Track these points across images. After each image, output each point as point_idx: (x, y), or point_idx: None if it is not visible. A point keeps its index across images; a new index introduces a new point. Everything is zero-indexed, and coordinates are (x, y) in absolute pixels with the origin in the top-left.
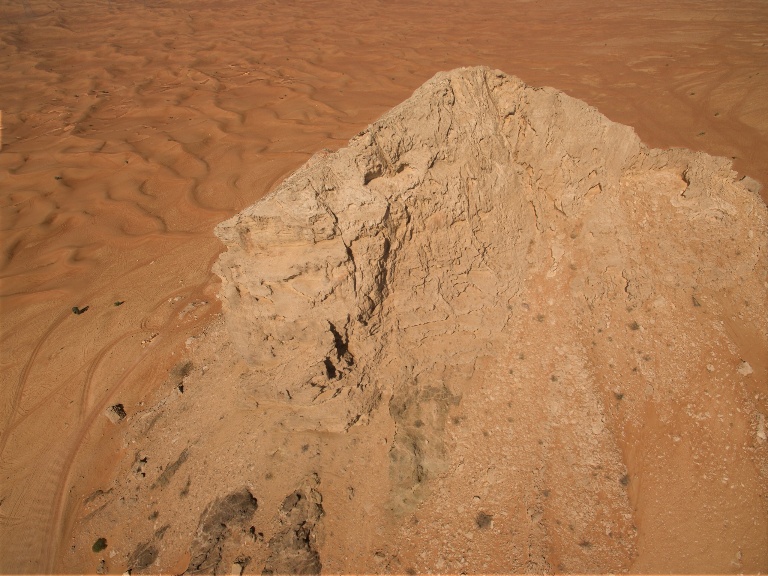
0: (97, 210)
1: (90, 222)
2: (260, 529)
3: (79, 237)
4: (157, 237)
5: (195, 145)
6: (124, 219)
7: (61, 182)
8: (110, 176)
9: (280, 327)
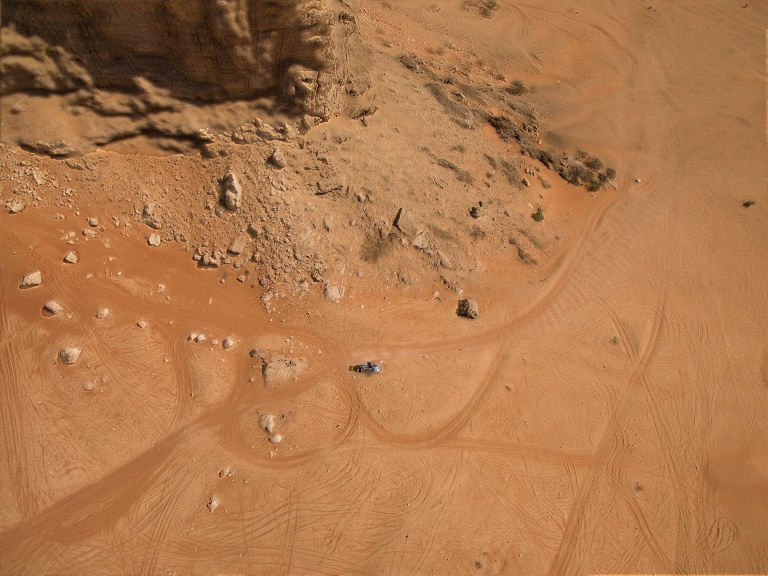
0: None
1: None
2: None
3: None
4: None
5: None
6: None
7: None
8: None
9: None
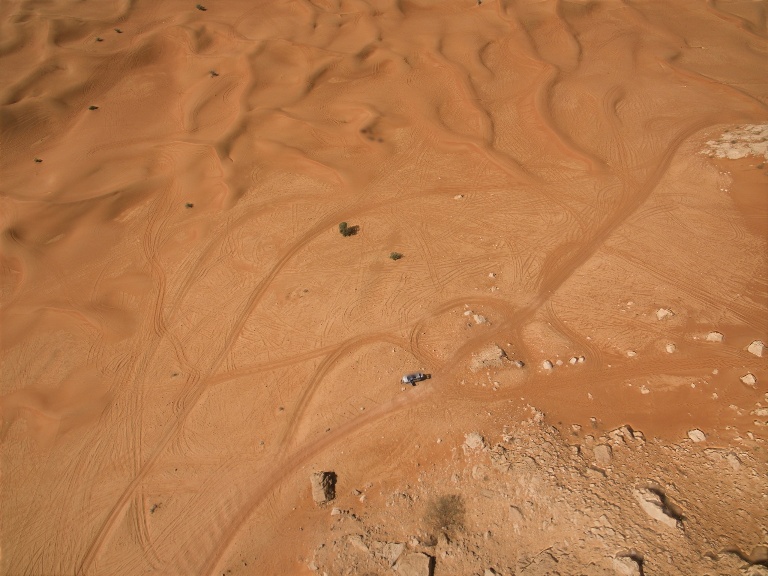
0: (419, 62)
1: (405, 77)
2: None
3: (386, 96)
4: (477, 150)
5: (574, 8)
6: (445, 93)
7: (397, 2)
8: (452, 15)
9: None
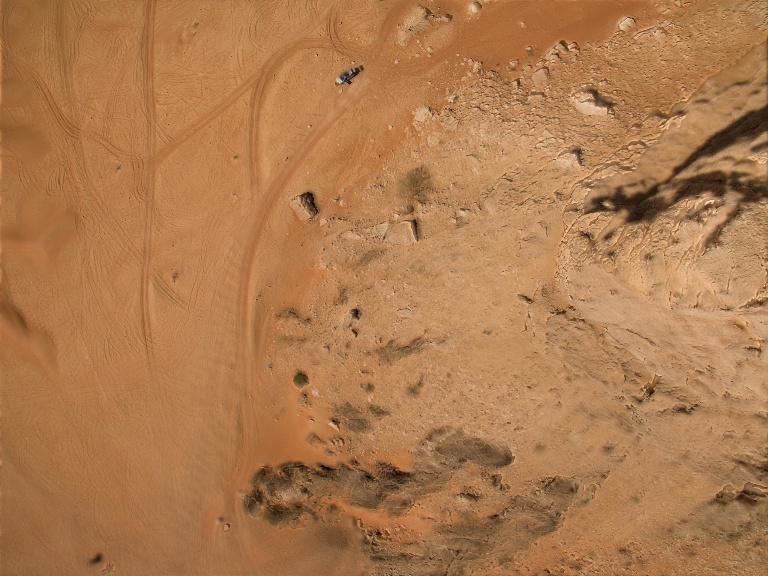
0: None
1: None
2: (508, 482)
3: None
4: None
5: None
6: None
7: None
8: None
9: (755, 407)
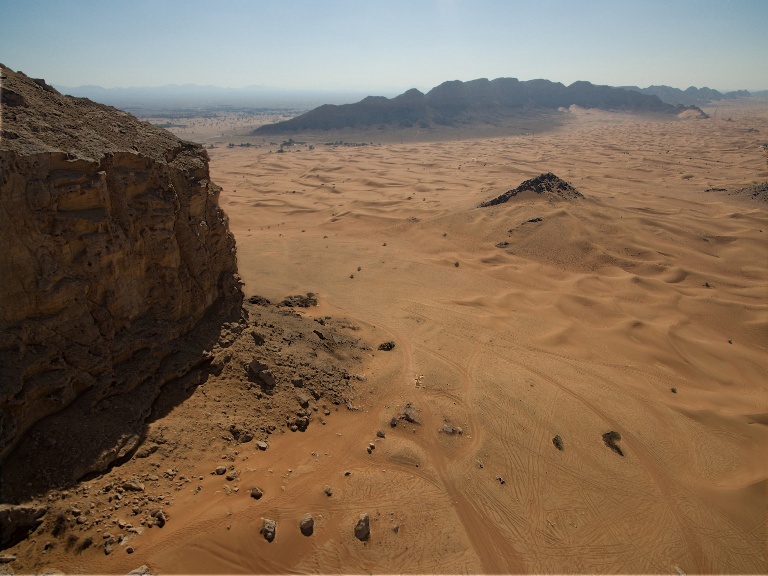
0: None
1: None
2: None
3: None
4: None
5: None
6: None
7: None
8: None
9: None
